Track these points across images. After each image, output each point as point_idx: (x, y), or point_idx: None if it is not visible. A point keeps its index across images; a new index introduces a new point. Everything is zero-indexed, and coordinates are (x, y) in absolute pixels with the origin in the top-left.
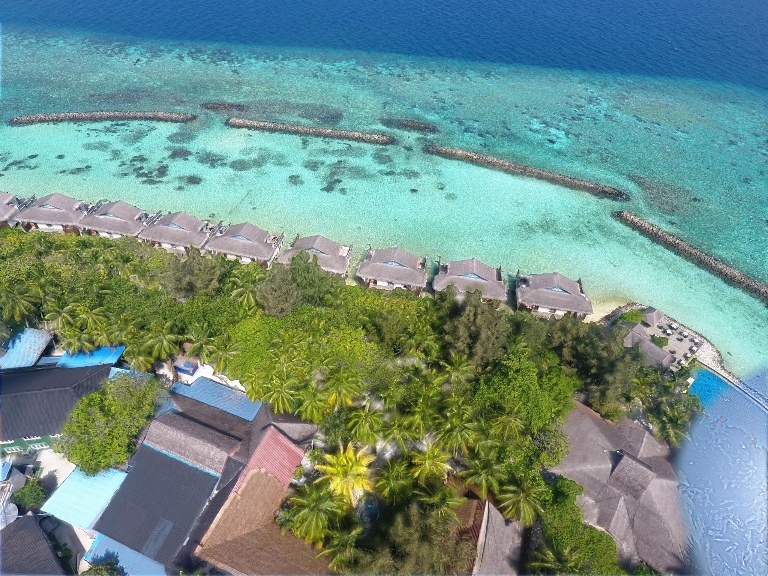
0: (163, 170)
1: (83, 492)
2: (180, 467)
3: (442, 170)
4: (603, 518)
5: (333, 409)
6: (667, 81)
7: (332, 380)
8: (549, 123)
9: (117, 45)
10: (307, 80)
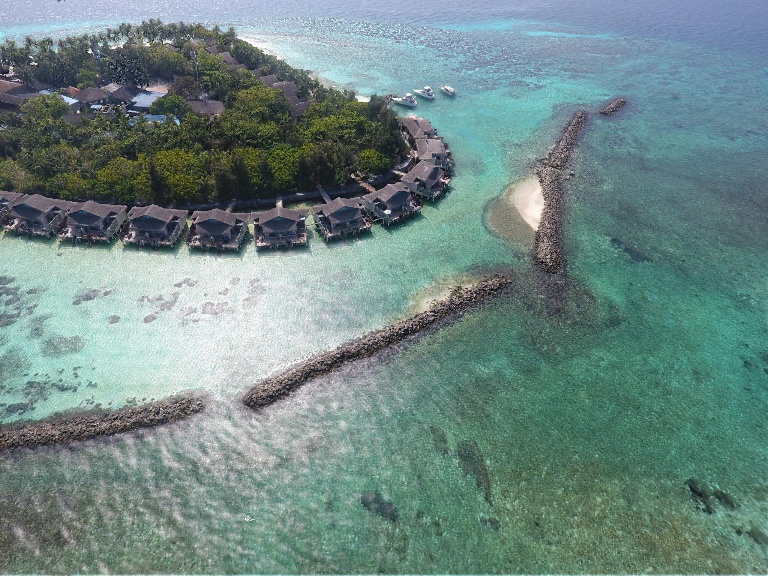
0: None
1: None
2: None
3: None
4: None
5: None
6: None
7: None
8: None
9: None
10: None
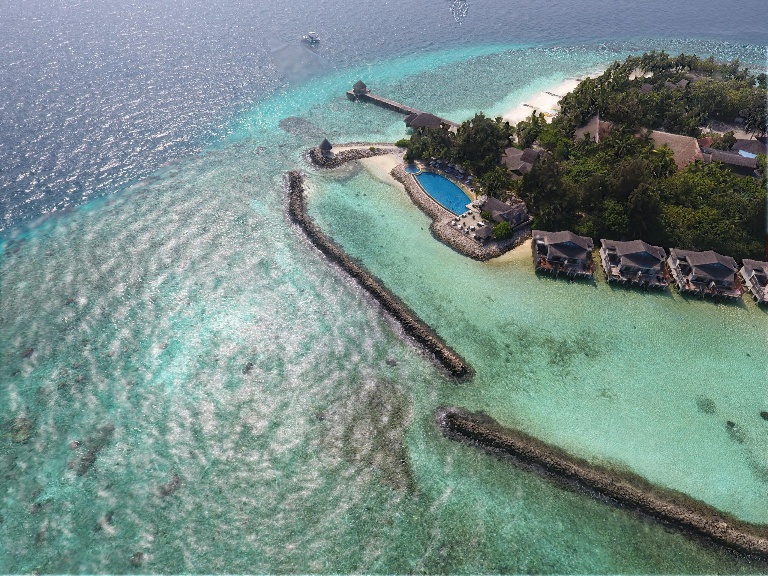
0: None
1: None
2: None
3: (760, 482)
4: None
5: None
6: None
7: None
8: None
9: None
10: None
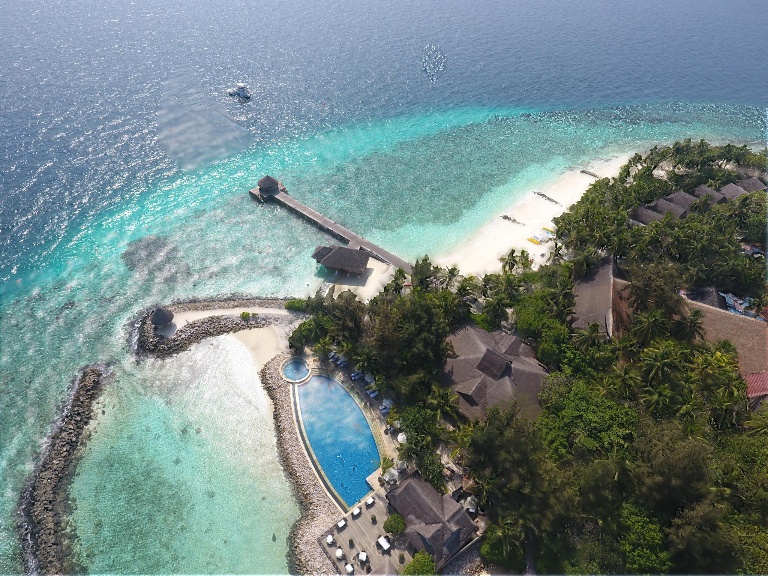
0: None
1: None
2: None
3: None
4: (518, 344)
5: None
6: None
7: None
8: None
9: None
10: None
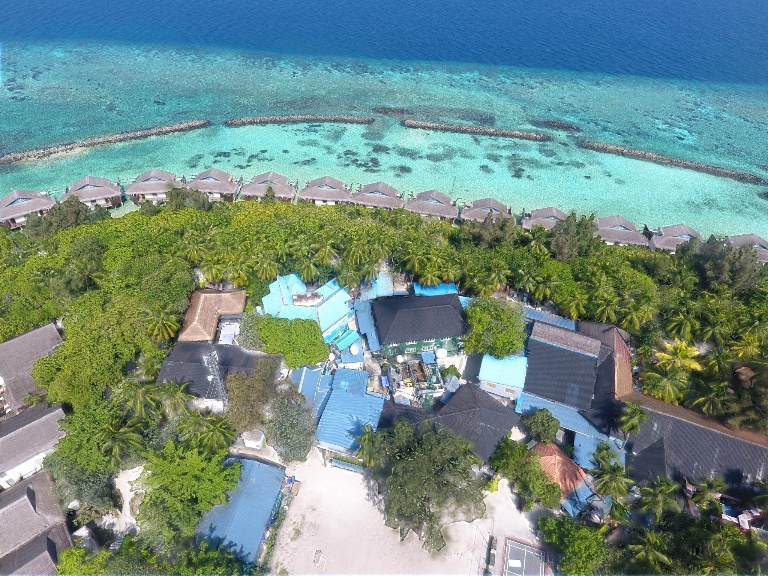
0: (376, 161)
1: (502, 368)
2: (566, 352)
3: (602, 161)
4: None
5: (641, 321)
6: (755, 88)
7: (645, 298)
8: (671, 123)
9: (267, 60)
10: (447, 89)
